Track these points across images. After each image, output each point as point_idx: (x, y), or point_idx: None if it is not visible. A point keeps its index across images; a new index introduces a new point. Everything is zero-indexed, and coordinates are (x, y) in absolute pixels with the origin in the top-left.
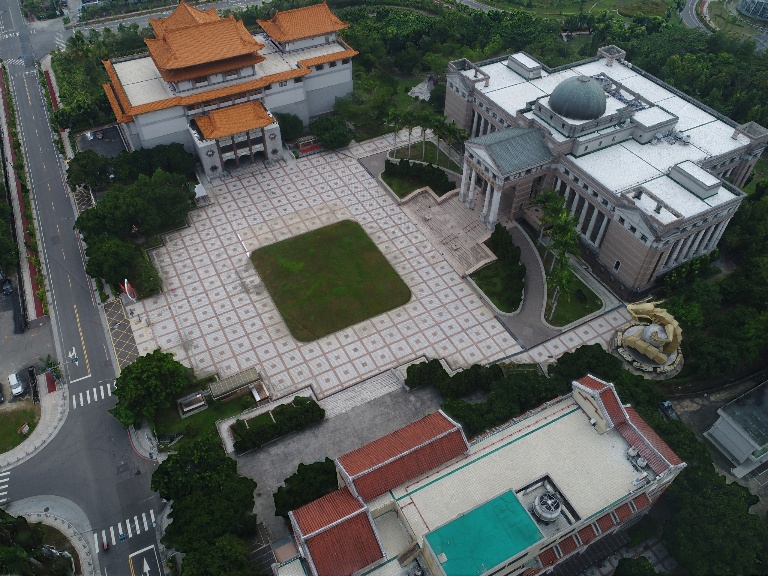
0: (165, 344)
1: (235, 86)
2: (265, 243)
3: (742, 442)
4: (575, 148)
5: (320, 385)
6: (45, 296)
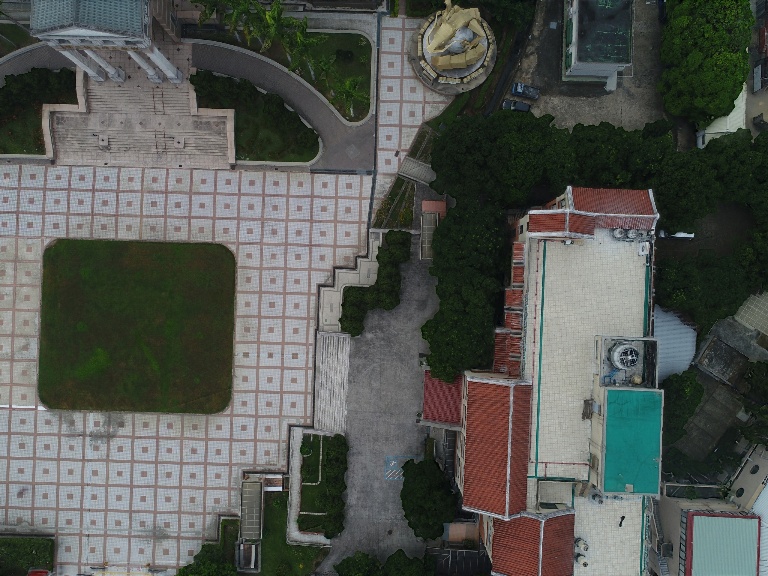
0: (144, 558)
1: None
2: (32, 379)
3: (606, 66)
4: None
5: (295, 416)
6: None
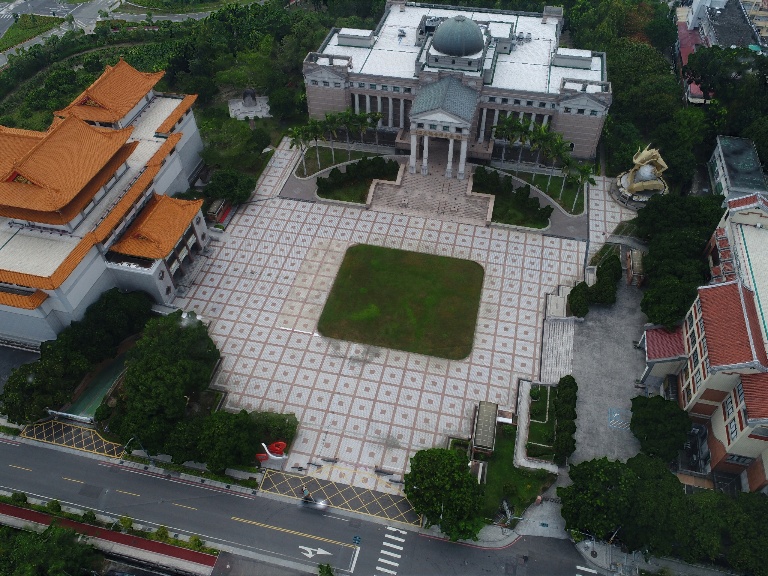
0: (373, 460)
1: (132, 188)
2: (316, 315)
3: None
4: (487, 77)
5: (524, 372)
6: (184, 542)
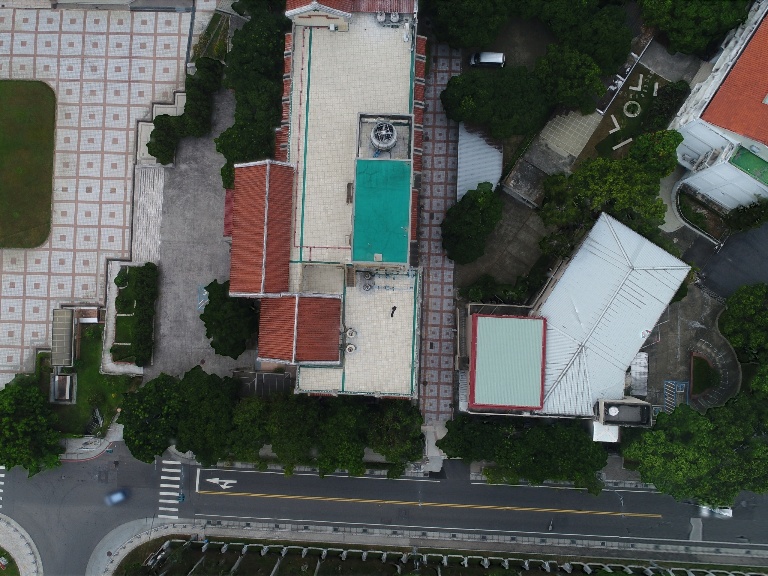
0: None
1: None
2: None
3: None
4: None
5: (113, 249)
6: None
